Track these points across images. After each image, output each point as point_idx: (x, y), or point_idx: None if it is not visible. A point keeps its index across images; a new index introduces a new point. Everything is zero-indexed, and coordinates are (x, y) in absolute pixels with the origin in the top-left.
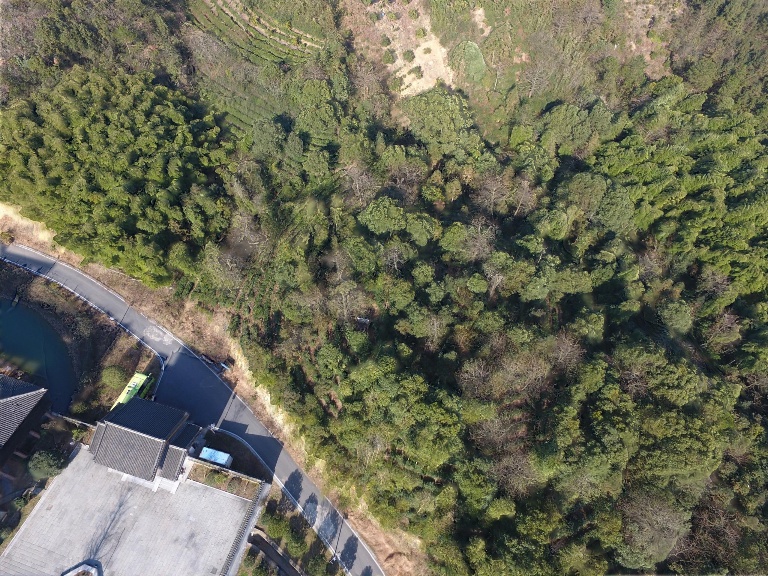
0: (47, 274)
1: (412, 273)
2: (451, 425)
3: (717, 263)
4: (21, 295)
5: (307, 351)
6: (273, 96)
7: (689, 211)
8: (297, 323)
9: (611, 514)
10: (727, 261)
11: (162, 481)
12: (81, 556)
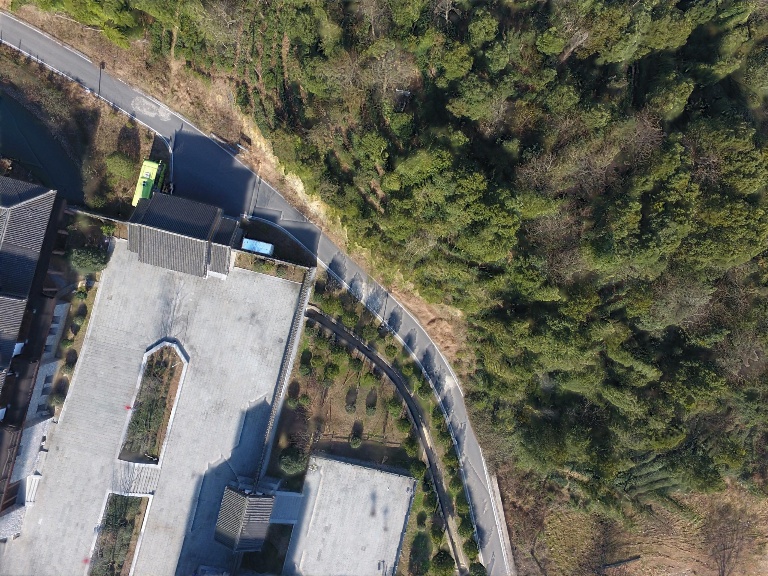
0: None
1: (469, 28)
2: (511, 226)
3: None
4: None
5: (339, 133)
6: None
7: None
8: (322, 97)
9: (645, 294)
10: None
11: None
12: (158, 335)
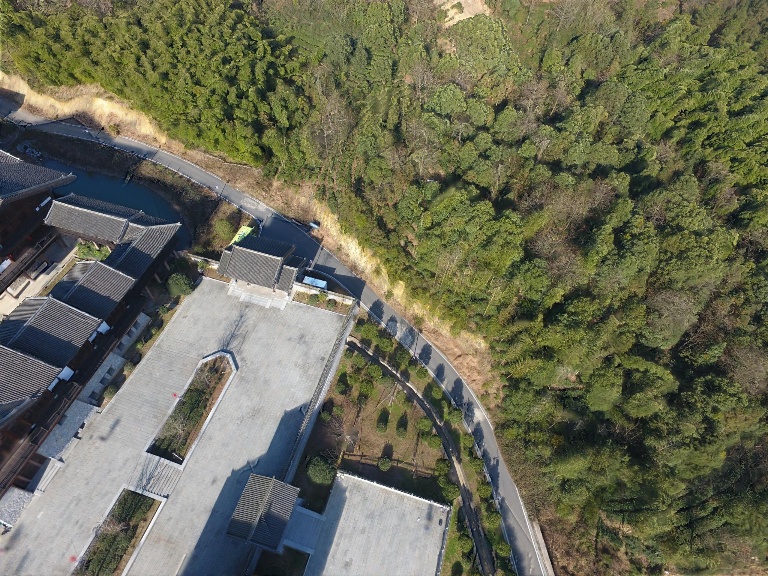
0: (153, 158)
1: (475, 140)
2: (516, 234)
3: (719, 160)
4: (133, 174)
5: (387, 205)
6: (337, 20)
7: (696, 122)
8: (377, 184)
9: (638, 304)
10: (728, 157)
11: (273, 301)
12: (216, 347)
